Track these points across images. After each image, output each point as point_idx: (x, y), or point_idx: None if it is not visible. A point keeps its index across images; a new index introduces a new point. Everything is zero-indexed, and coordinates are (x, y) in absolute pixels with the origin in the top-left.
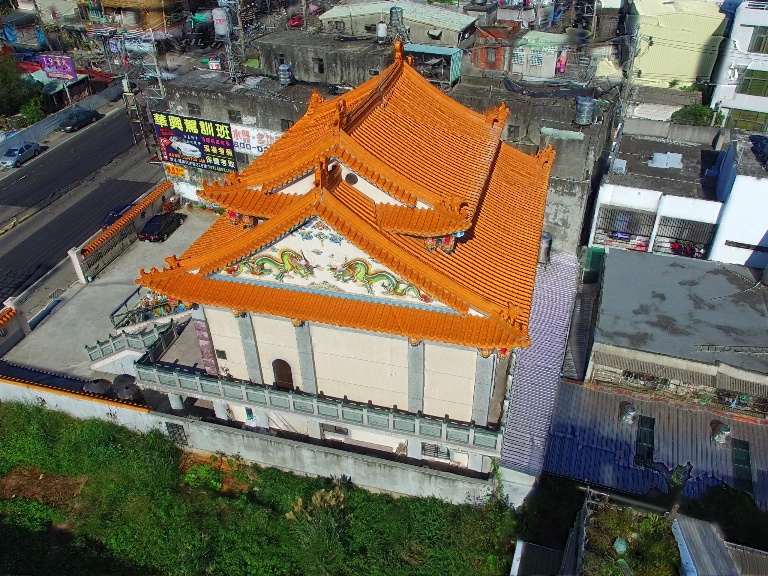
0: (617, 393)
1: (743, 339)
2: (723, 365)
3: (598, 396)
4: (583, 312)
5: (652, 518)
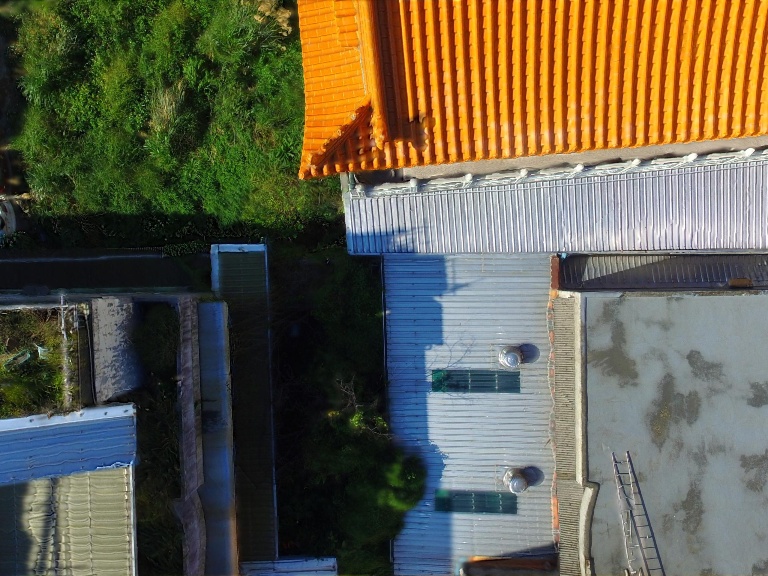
0: (551, 339)
1: (673, 529)
2: (590, 493)
3: (536, 312)
4: (764, 270)
5: (72, 387)
